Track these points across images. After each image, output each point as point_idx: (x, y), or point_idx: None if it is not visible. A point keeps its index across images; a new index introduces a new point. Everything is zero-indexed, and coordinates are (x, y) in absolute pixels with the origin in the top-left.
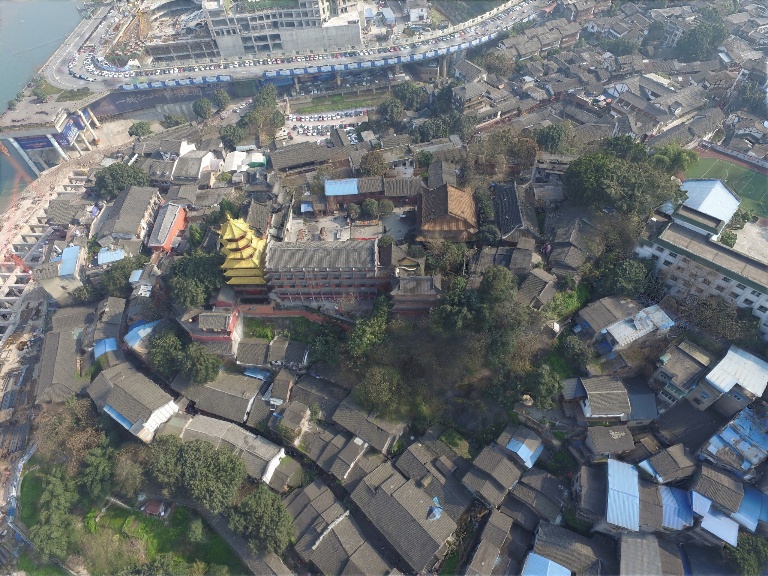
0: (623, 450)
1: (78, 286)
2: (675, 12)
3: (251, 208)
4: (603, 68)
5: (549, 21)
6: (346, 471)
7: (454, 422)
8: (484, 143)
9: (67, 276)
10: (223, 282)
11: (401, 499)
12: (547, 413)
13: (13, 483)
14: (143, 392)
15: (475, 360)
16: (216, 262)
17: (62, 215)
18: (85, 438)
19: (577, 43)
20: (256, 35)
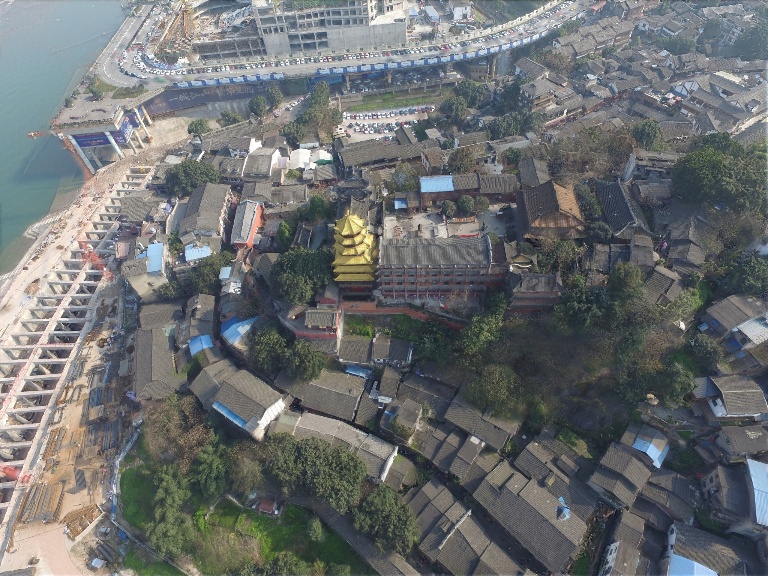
0: (759, 450)
1: (164, 283)
2: (728, 10)
3: (352, 204)
4: (666, 66)
5: (602, 19)
6: (467, 470)
7: (568, 421)
8: (571, 140)
9: (155, 273)
10: (331, 279)
11: (528, 499)
12: (674, 412)
13: (111, 480)
14: (253, 389)
15: (604, 358)
16: (323, 259)
17: (135, 212)
18: (198, 435)
19: (633, 41)
20: (303, 33)
